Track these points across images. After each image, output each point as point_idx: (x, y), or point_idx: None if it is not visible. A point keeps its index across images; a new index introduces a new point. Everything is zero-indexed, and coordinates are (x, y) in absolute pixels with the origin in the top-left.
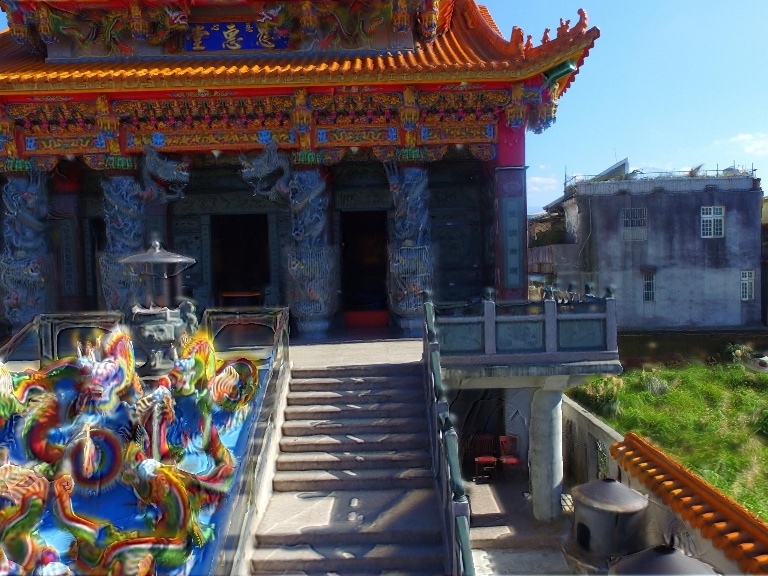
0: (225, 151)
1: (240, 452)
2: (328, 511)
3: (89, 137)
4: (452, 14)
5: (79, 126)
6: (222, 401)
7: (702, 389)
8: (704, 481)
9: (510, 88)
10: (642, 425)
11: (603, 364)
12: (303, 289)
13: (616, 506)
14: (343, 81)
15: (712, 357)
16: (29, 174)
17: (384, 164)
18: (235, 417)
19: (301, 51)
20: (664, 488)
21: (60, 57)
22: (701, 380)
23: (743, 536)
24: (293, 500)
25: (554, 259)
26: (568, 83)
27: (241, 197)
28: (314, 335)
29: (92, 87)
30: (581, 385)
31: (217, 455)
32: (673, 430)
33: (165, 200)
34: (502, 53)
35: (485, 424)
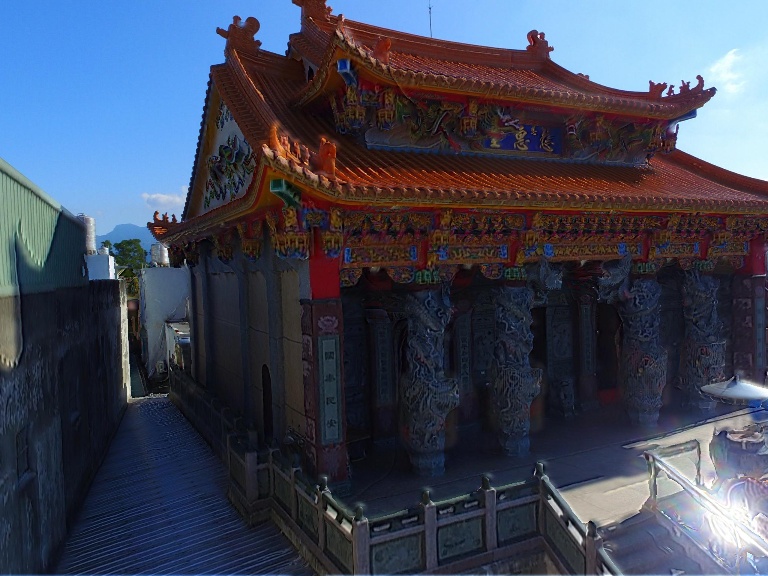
0: (595, 261)
1: None
2: None
3: (494, 247)
4: None
5: (492, 236)
6: None
7: None
8: None
9: None
10: None
11: None
12: (647, 384)
13: None
14: (708, 210)
15: None
16: (442, 286)
17: (685, 271)
18: None
19: (579, 159)
20: None
21: (382, 143)
22: None
23: None
24: None
25: None
26: None
27: None
28: (655, 424)
29: (547, 205)
30: None
31: None
32: None
33: (532, 306)
34: (737, 183)
35: None
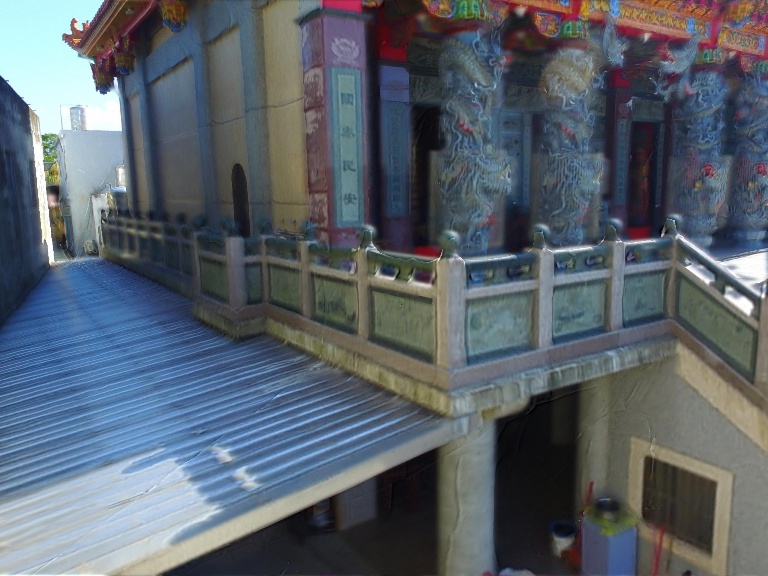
0: (661, 36)
1: None
2: None
3: None
4: None
5: None
6: None
7: None
8: None
9: None
10: None
11: None
12: (704, 201)
13: None
14: None
15: None
16: (491, 28)
17: (745, 74)
18: None
19: None
20: None
21: None
22: None
23: None
24: None
25: None
26: None
27: None
28: None
29: None
30: None
31: None
32: None
33: None
34: None
35: None
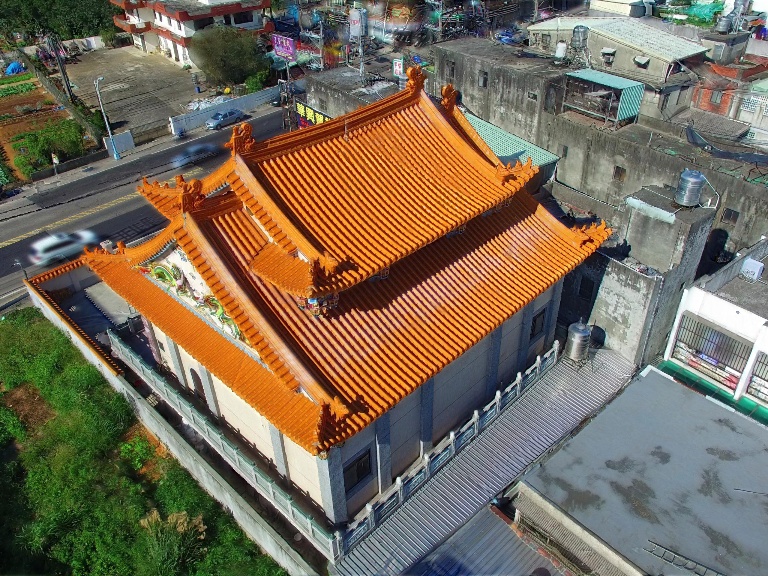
0: None
1: None
2: None
3: None
4: None
5: None
6: None
7: None
8: None
9: None
10: None
11: None
12: None
13: None
14: None
15: None
16: None
17: None
18: None
19: None
20: None
21: None
22: None
23: (90, 341)
24: None
25: None
26: None
27: None
28: None
29: None
30: None
31: None
32: None
33: None
34: None
35: None
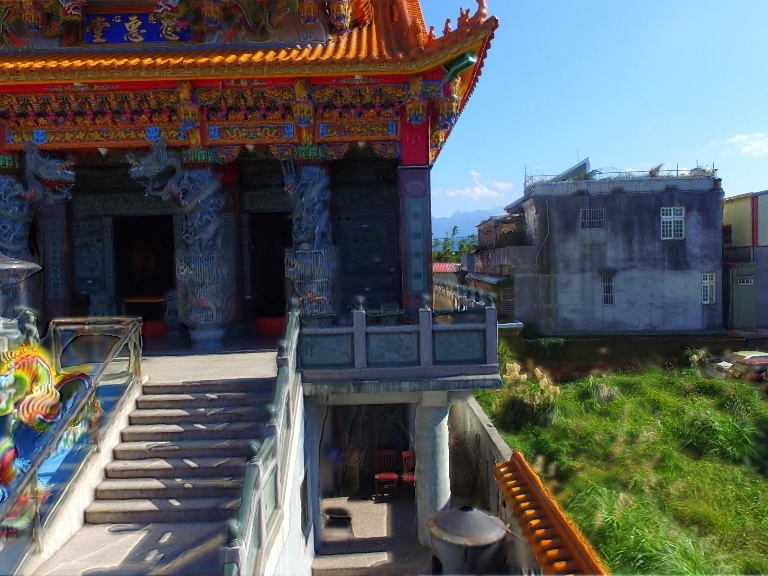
0: (111, 149)
1: (58, 479)
2: (129, 548)
3: None
4: (381, 7)
5: None
6: (34, 423)
7: (650, 396)
8: (600, 503)
9: (408, 82)
10: (572, 436)
11: (481, 379)
12: (194, 295)
13: (466, 539)
14: (227, 74)
15: (669, 362)
16: None
17: (282, 163)
18: (63, 439)
19: (205, 44)
20: (524, 518)
21: None
22: (654, 386)
23: None
24: (100, 534)
25: (511, 261)
26: (474, 77)
27: (144, 198)
28: (206, 344)
29: None
30: (519, 393)
31: (10, 485)
32: (602, 442)
33: (52, 201)
34: (408, 45)
35: (378, 440)
